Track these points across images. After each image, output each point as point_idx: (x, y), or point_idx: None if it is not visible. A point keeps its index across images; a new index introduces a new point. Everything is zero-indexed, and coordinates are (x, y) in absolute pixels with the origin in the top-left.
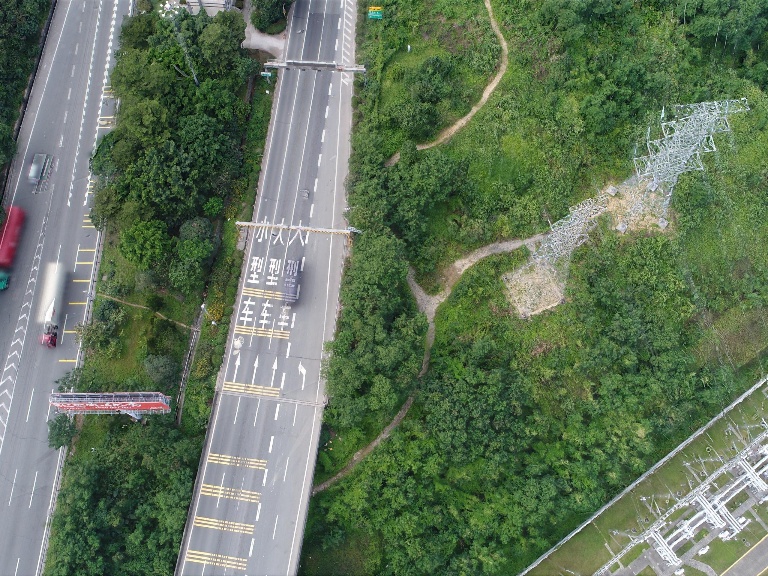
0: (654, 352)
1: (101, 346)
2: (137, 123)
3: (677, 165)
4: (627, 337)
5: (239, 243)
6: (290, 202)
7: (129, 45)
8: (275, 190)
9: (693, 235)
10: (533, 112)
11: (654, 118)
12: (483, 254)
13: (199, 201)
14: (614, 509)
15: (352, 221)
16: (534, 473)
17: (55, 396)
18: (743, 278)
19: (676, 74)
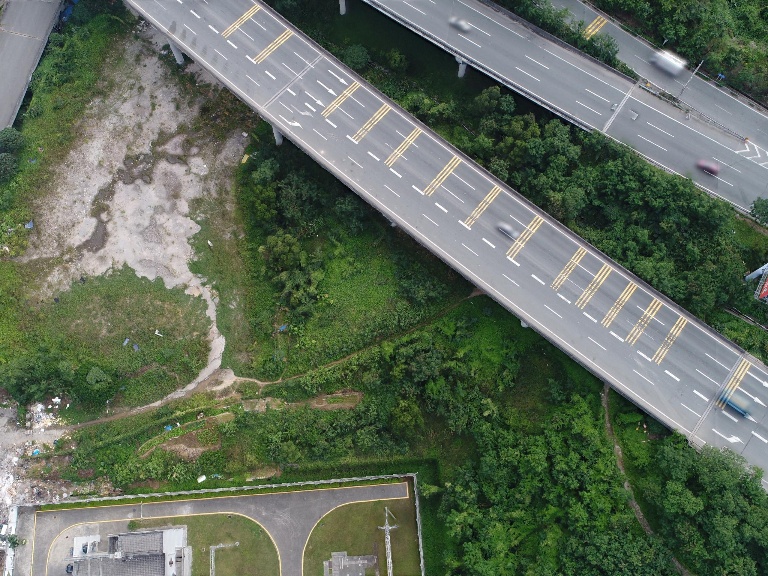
0: None
1: None
2: None
3: None
4: None
5: None
6: None
7: None
8: None
9: None
10: None
11: None
12: None
13: None
14: None
15: None
16: None
17: None
18: None
19: None
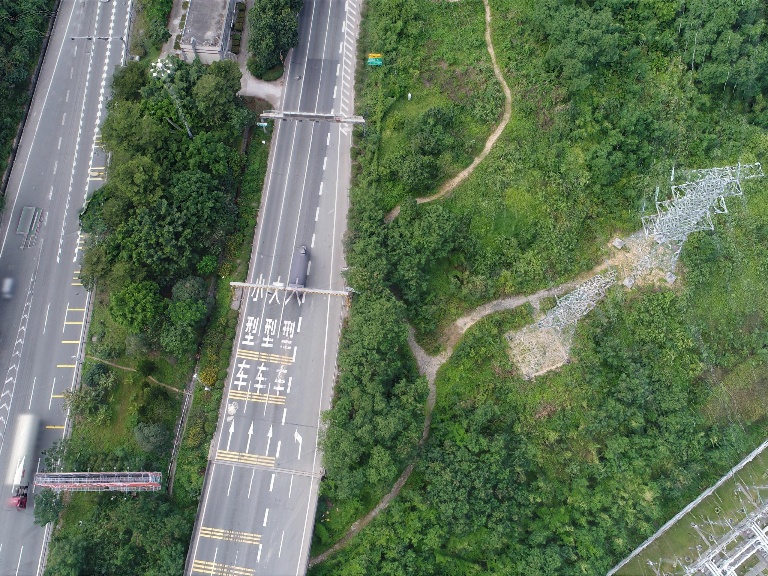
0: (662, 412)
1: (90, 413)
2: (128, 181)
3: (687, 225)
4: (634, 398)
5: (234, 302)
6: (286, 259)
7: (121, 96)
8: (271, 246)
9: (702, 290)
10: (537, 164)
11: (661, 168)
12: (486, 312)
13: (192, 260)
14: (620, 573)
15: (350, 282)
16: (538, 542)
17: (40, 476)
18: (753, 333)
19: (684, 122)
